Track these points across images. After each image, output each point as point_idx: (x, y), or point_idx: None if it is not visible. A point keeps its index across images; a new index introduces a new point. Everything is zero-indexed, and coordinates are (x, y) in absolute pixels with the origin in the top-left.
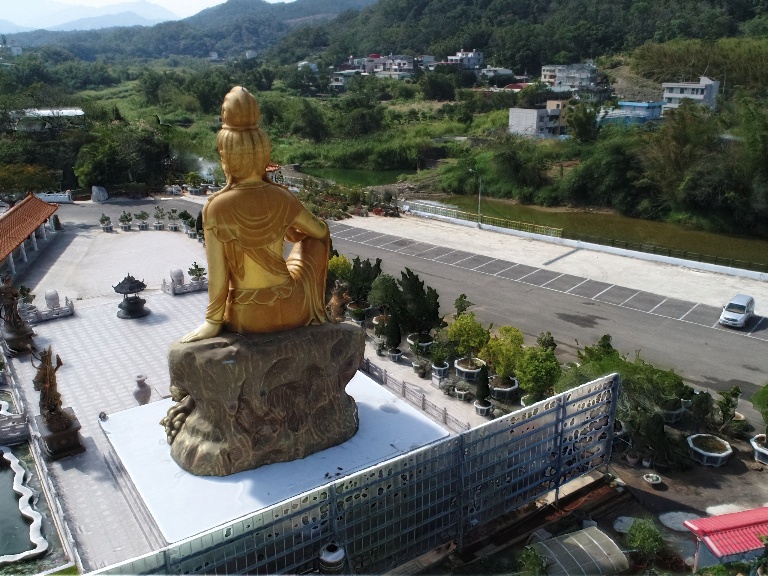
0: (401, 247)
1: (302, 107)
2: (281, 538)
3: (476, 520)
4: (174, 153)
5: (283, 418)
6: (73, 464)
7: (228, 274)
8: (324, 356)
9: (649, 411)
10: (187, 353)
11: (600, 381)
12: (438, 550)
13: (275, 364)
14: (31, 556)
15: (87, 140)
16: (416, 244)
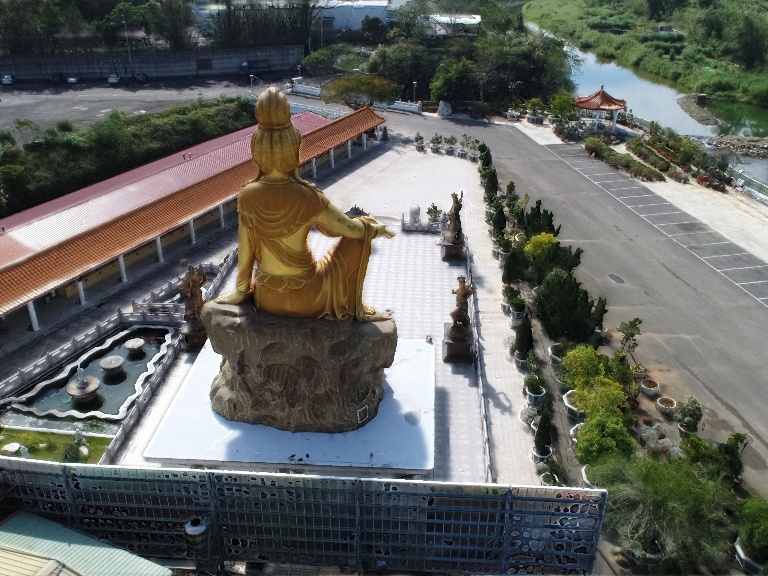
0: (681, 232)
1: (741, 25)
2: (164, 494)
3: (385, 562)
4: (547, 72)
5: (280, 392)
6: (194, 360)
7: (252, 254)
8: (321, 351)
9: (665, 551)
10: (209, 312)
11: (576, 491)
12: (342, 569)
13: (272, 345)
14: (111, 419)
15: (469, 50)
16: (704, 232)
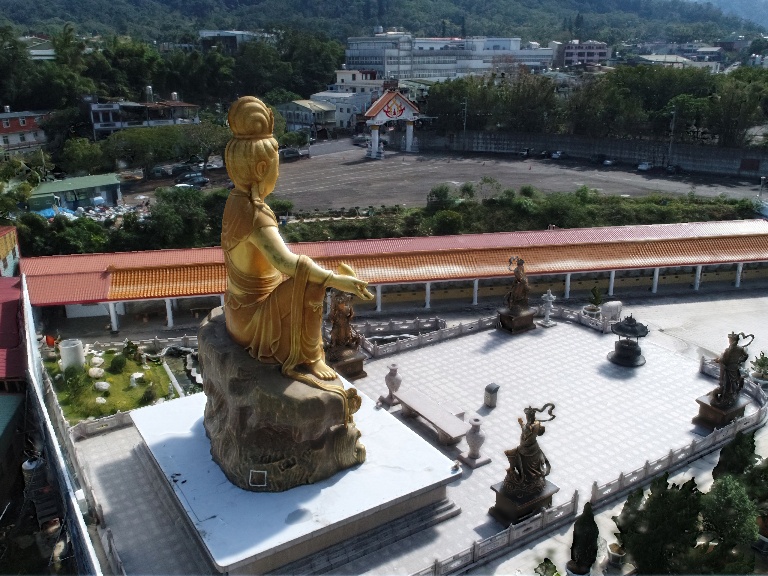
0: None
1: None
2: None
3: None
4: None
5: None
6: None
7: None
8: None
9: None
10: None
11: None
12: None
13: None
14: None
15: None
16: None
